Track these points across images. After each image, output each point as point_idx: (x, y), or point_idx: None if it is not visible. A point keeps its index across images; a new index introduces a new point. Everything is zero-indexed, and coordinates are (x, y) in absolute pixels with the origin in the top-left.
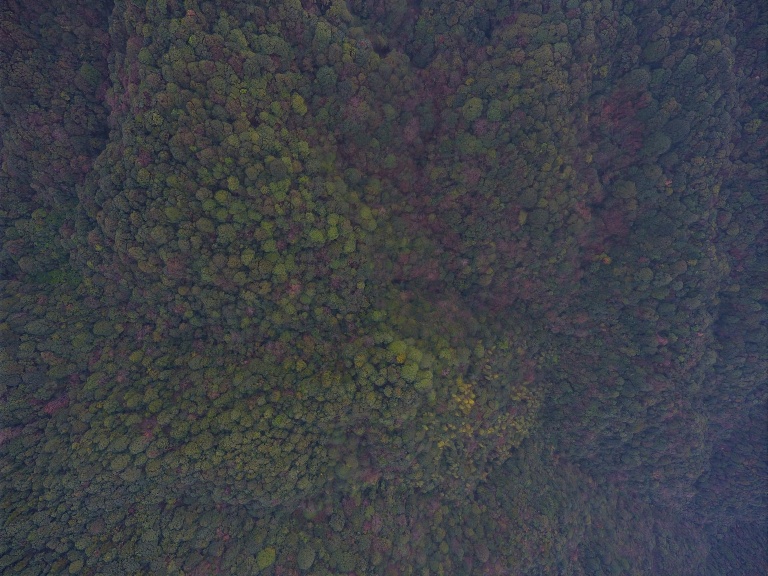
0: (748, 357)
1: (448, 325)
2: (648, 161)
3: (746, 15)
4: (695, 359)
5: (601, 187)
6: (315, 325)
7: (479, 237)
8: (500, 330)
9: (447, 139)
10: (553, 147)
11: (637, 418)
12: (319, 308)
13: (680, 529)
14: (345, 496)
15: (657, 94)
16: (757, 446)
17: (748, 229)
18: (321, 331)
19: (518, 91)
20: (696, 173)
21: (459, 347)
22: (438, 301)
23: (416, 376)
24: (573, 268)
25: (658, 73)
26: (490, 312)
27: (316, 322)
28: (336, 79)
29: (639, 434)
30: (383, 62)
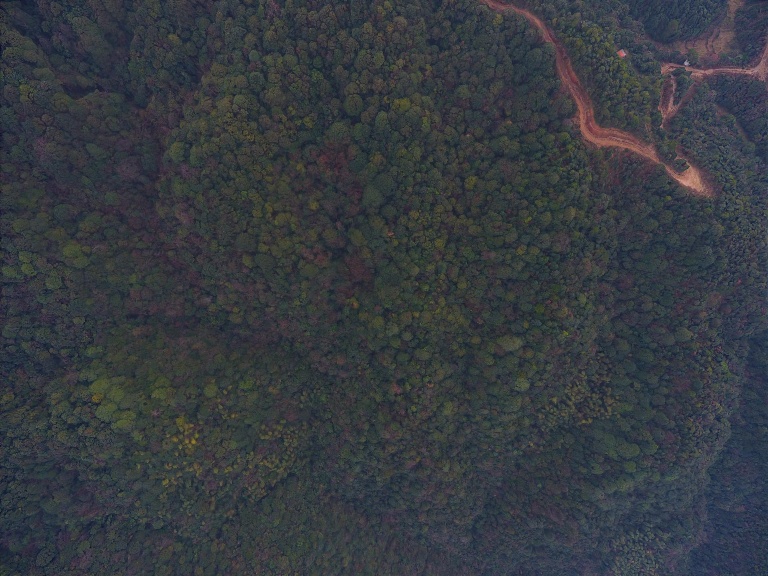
0: (491, 409)
1: (178, 363)
2: (369, 211)
3: (445, 74)
4: (430, 409)
5: (336, 233)
6: (29, 358)
7: (215, 276)
8: (247, 369)
9: (164, 180)
10: (254, 195)
11: (384, 464)
12: (26, 342)
13: (455, 574)
14: (62, 530)
15: (365, 147)
16: (520, 496)
17: (474, 284)
18: (35, 364)
19: (209, 139)
20: (412, 226)
21: (183, 386)
22: (178, 337)
23: (111, 416)
24: (327, 310)
25: (356, 127)
26: (250, 349)
27: (30, 355)
28: (18, 119)
29: (394, 479)
30: (76, 103)
